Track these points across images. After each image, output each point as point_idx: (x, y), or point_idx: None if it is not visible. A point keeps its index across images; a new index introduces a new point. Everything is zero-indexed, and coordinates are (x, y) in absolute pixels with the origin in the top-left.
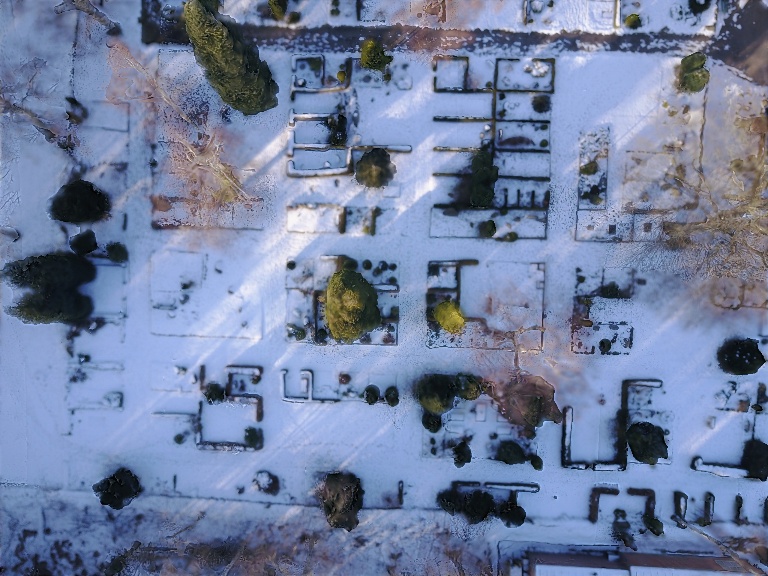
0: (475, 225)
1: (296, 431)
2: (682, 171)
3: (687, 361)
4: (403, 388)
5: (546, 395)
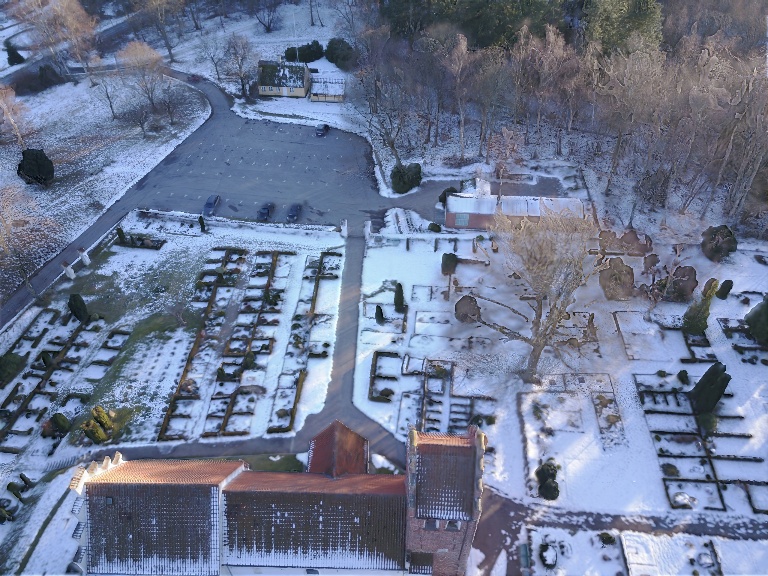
0: (693, 384)
1: (760, 282)
2: (537, 415)
3: (503, 311)
4: (700, 298)
5: (619, 273)
